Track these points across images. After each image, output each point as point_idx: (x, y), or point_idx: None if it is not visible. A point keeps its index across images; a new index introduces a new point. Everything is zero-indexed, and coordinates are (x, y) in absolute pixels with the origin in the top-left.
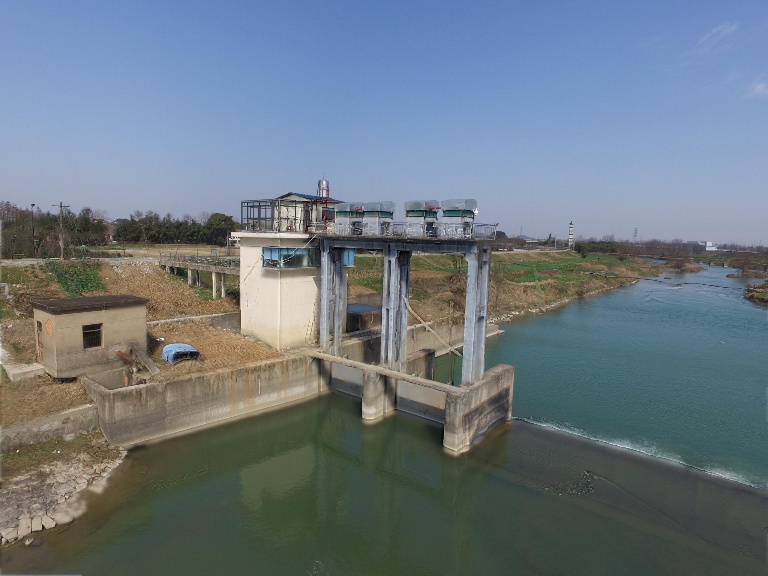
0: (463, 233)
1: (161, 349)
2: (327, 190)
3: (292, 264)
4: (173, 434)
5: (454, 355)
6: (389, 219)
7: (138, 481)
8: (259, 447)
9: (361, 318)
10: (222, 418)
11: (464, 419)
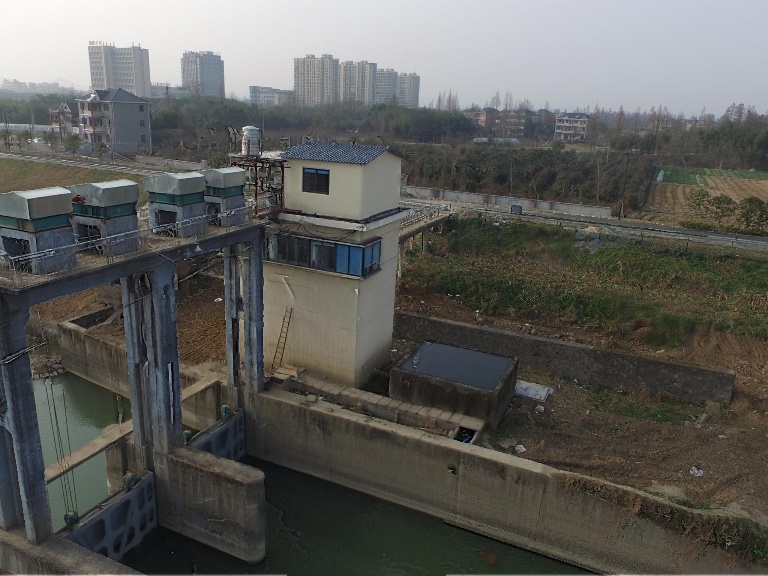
0: None
1: (187, 308)
2: (246, 143)
3: None
4: (93, 383)
5: None
6: (175, 206)
7: None
8: None
9: (394, 377)
10: (124, 394)
11: None
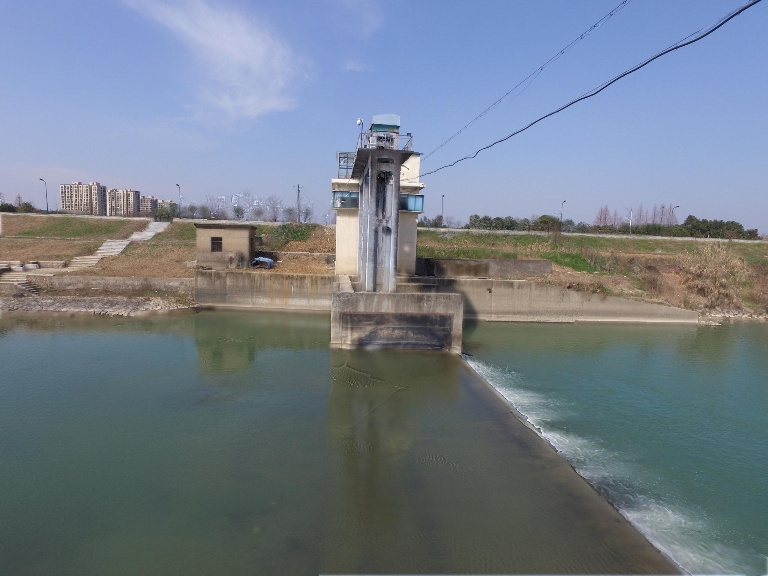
0: (377, 147)
1: None
2: None
3: (347, 205)
4: (230, 307)
5: (570, 326)
6: None
7: (182, 316)
8: (291, 338)
9: (437, 265)
10: (263, 306)
11: (344, 317)
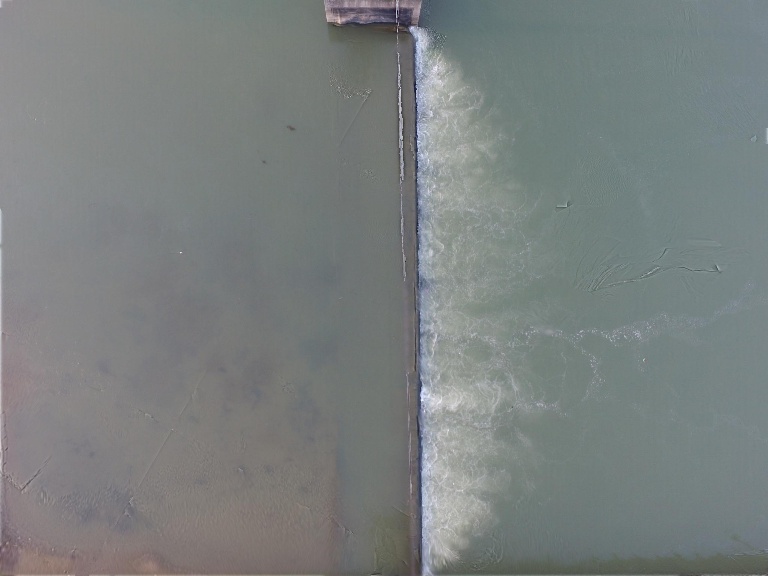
0: None
1: None
2: None
3: None
4: None
5: None
6: None
7: None
8: None
9: None
10: None
11: (334, 10)
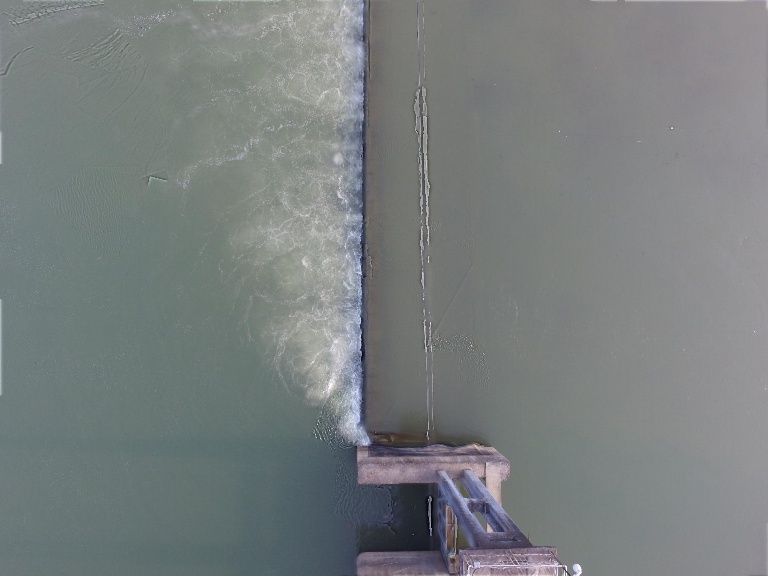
0: None
1: None
2: None
3: None
4: None
5: None
6: None
7: None
8: None
9: None
10: None
11: None
